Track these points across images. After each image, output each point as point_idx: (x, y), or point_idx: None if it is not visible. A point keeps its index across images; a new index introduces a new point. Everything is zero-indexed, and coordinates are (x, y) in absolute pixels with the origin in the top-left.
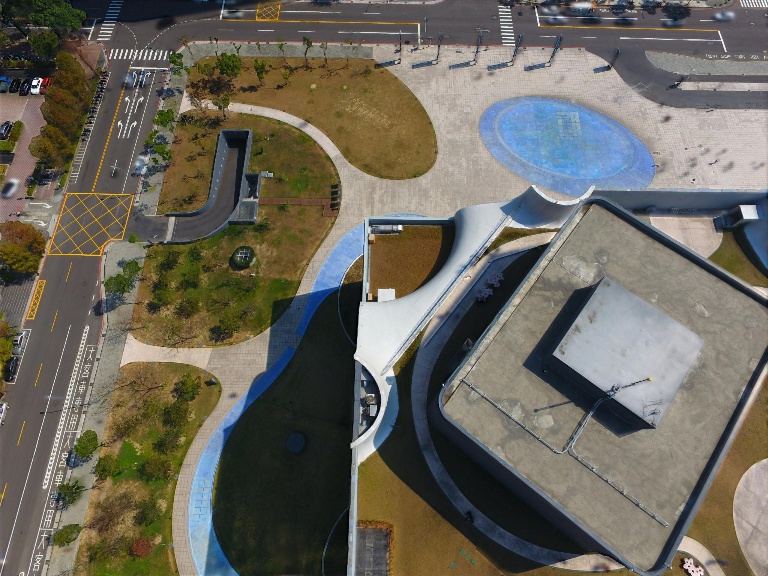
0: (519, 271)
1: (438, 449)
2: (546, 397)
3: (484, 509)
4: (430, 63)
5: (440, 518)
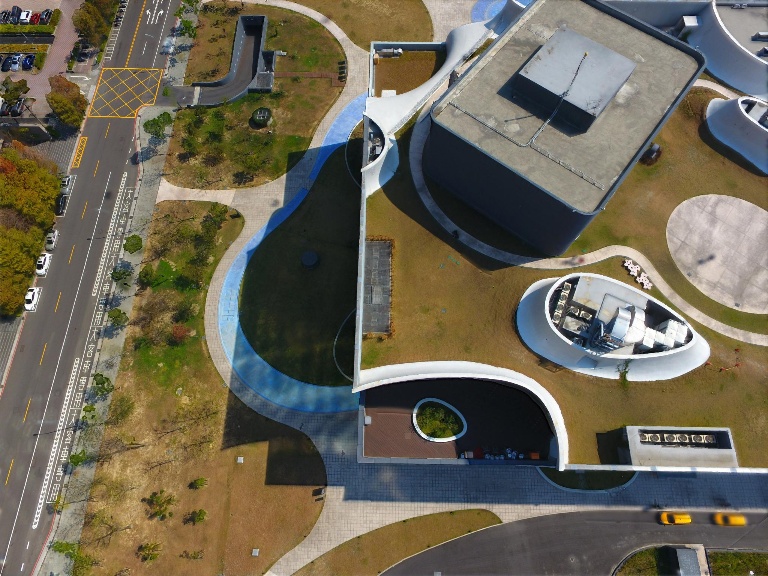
0: None
1: (431, 191)
2: (514, 113)
3: (467, 230)
4: None
5: (432, 236)
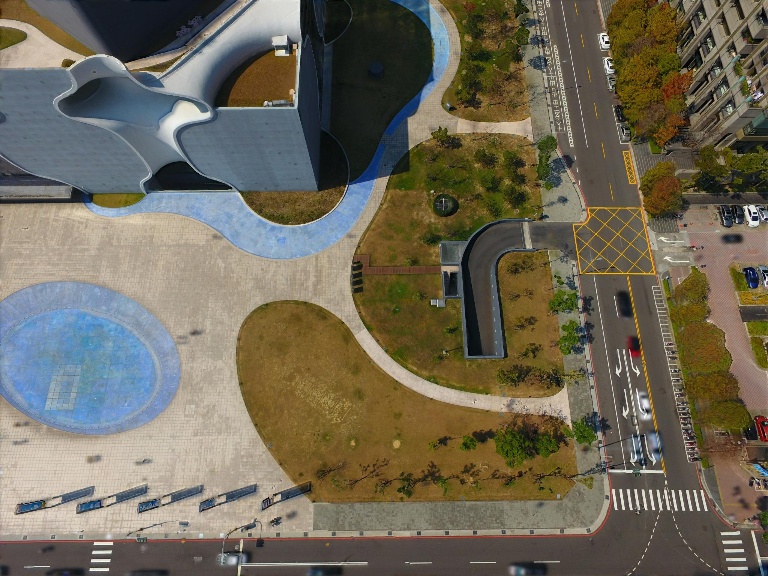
0: (162, 41)
1: None
2: None
3: None
4: (230, 497)
5: None
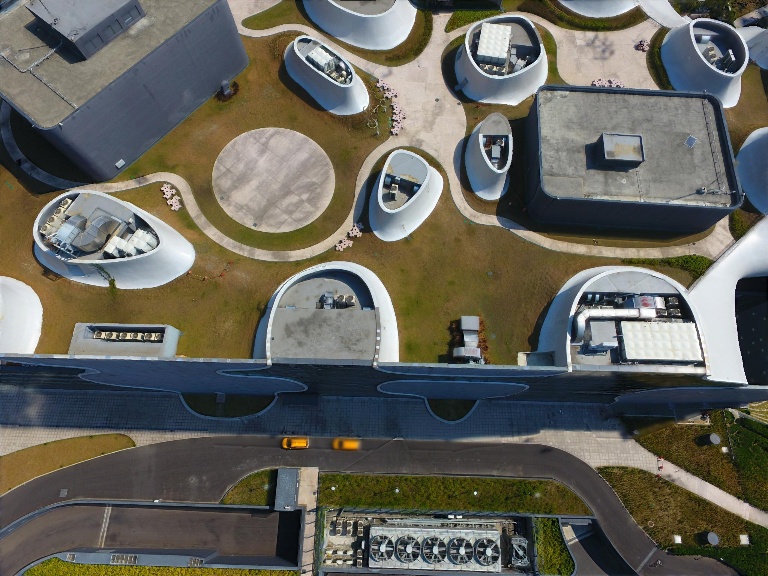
0: None
1: (13, 125)
2: (31, 43)
3: (32, 158)
4: None
5: None
